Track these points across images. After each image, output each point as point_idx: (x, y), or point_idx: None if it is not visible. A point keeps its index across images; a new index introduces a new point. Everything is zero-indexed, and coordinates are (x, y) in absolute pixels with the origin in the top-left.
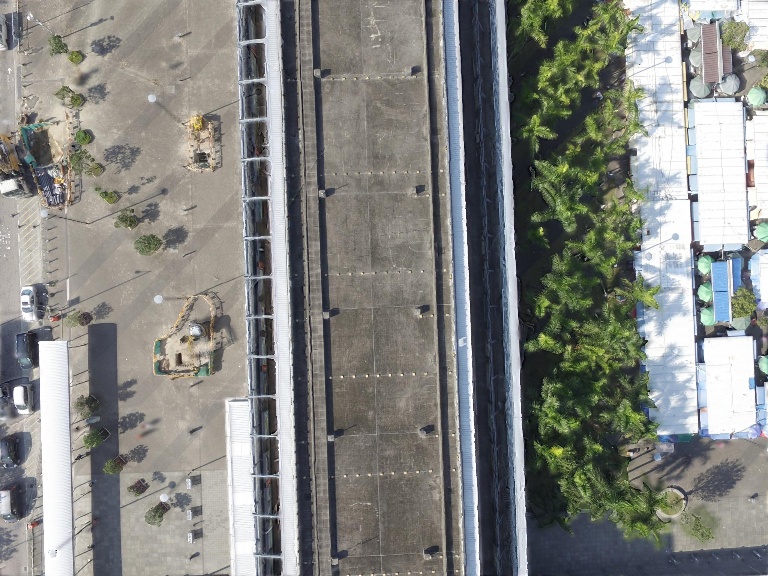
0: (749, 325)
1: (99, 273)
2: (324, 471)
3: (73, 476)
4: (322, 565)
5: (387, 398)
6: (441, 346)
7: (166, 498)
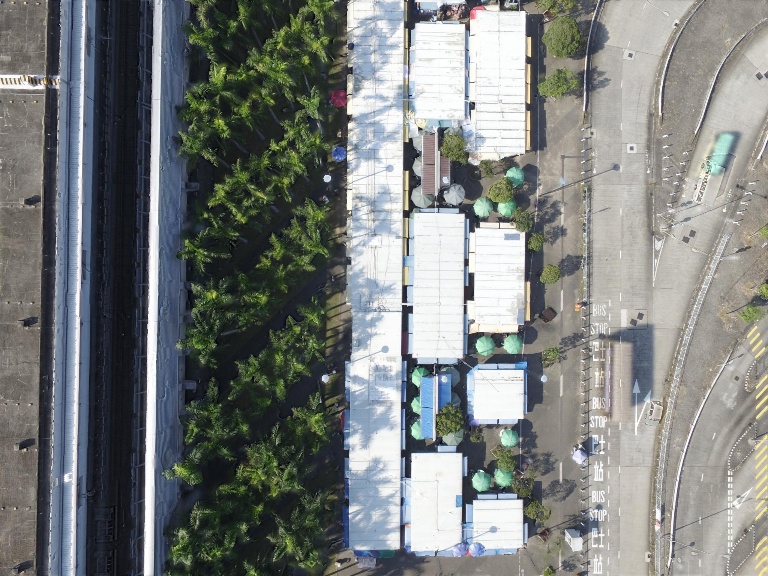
0: (462, 441)
1: None
2: None
3: None
4: None
5: None
6: (46, 481)
7: None
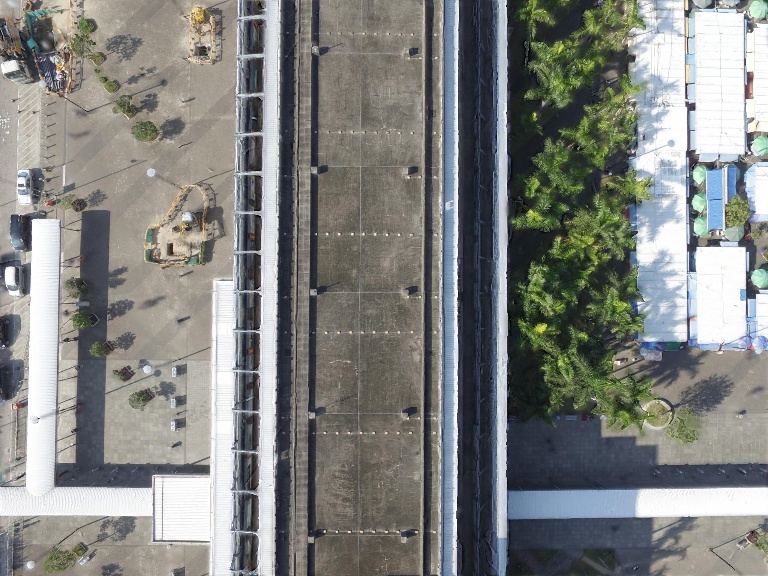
0: None
1: (95, 160)
2: (305, 325)
3: (60, 357)
4: (299, 419)
5: (371, 257)
6: (428, 208)
7: (149, 370)
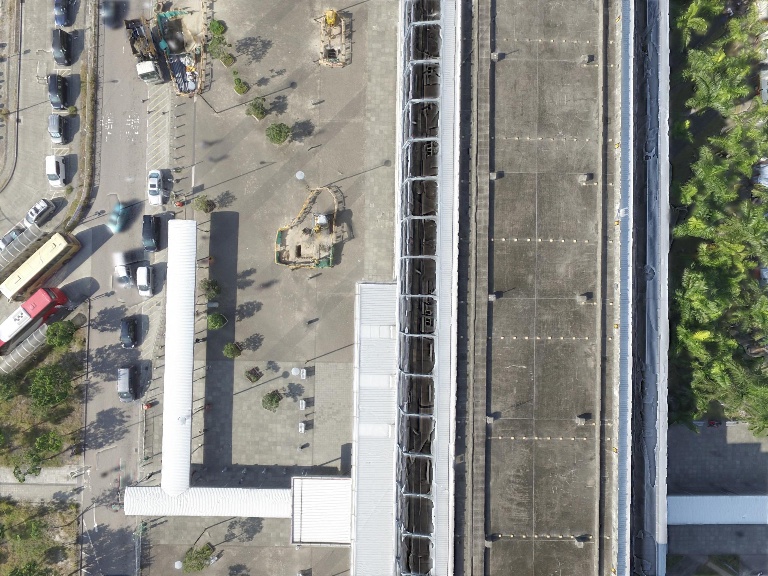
0: None
1: (225, 162)
2: (483, 330)
3: None
4: (477, 423)
5: (547, 263)
6: (603, 215)
7: (298, 372)
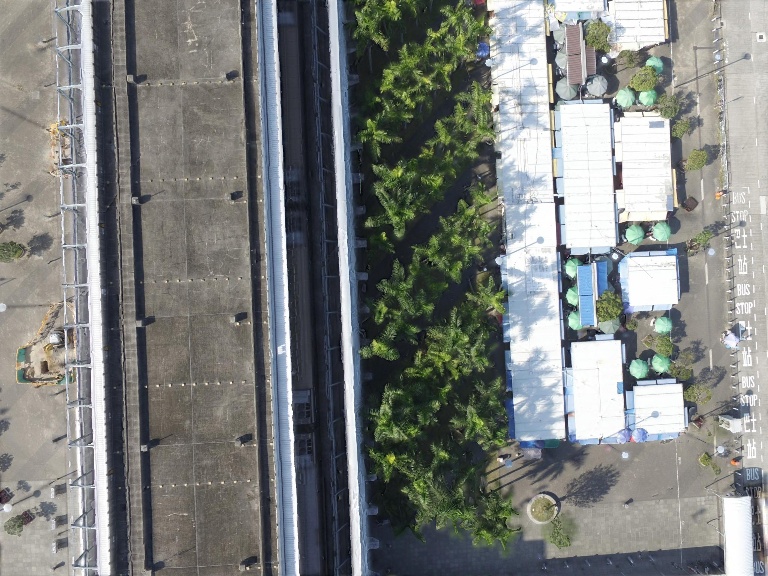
0: (618, 329)
1: None
2: (137, 481)
3: None
4: None
5: (204, 407)
6: (259, 354)
7: (10, 508)
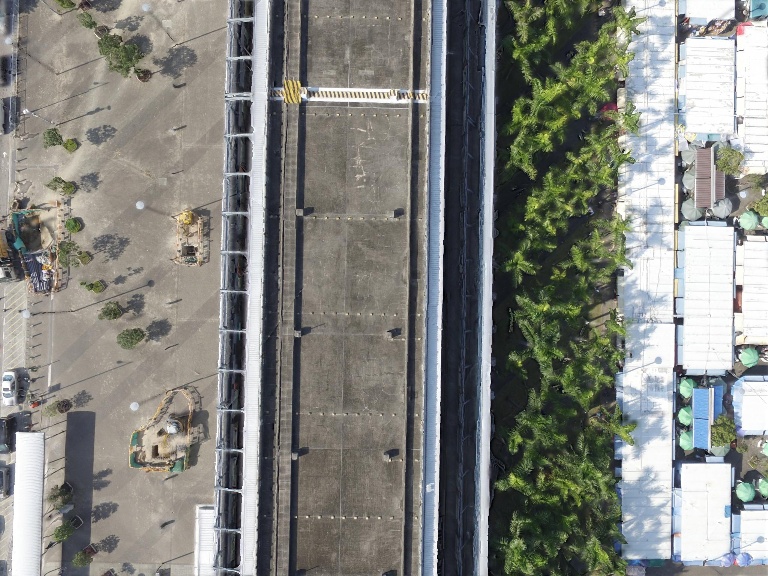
0: (728, 451)
1: (81, 361)
2: None
3: (43, 565)
4: None
5: (351, 541)
6: (408, 491)
7: None
